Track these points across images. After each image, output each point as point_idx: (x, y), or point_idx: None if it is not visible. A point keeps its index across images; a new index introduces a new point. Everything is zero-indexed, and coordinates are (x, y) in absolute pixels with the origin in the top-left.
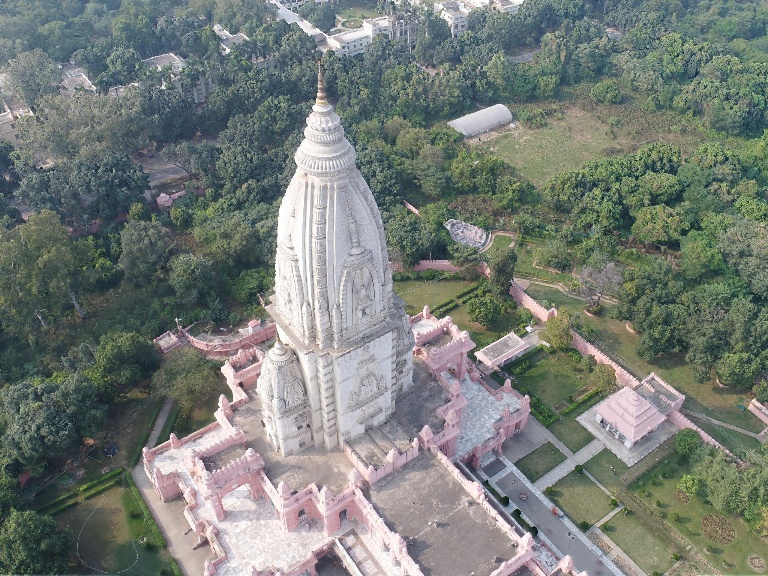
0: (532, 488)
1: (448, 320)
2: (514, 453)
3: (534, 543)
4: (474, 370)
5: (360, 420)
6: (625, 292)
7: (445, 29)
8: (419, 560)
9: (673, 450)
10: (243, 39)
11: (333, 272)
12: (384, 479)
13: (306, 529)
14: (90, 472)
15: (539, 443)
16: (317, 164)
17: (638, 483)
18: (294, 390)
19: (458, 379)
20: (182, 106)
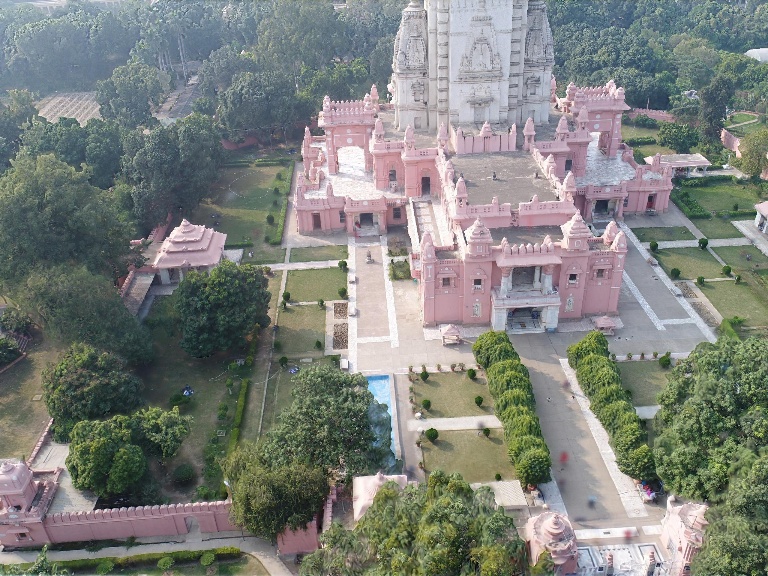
0: (637, 244)
1: (610, 84)
2: (637, 223)
3: None
4: None
5: (469, 99)
6: None
7: None
8: None
9: None
10: None
11: None
12: (471, 154)
13: (392, 191)
14: (270, 156)
15: (671, 224)
16: None
17: None
18: (416, 47)
19: (608, 157)
20: None
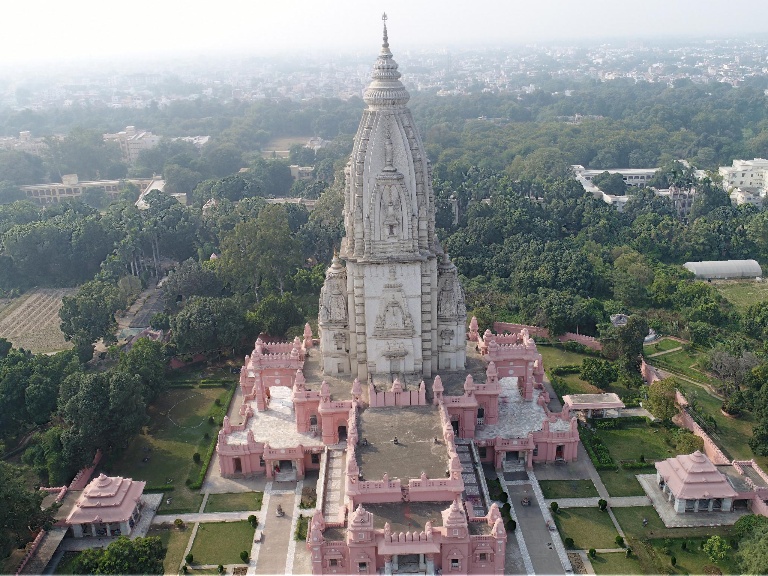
0: (541, 501)
1: (524, 331)
2: (545, 474)
3: (461, 470)
4: (547, 400)
5: (384, 353)
6: (748, 373)
7: (723, 198)
8: (361, 455)
9: (734, 533)
10: (521, 179)
11: (368, 183)
12: (383, 408)
13: (312, 435)
14: (215, 376)
15: (578, 477)
16: (371, 93)
17: (664, 540)
18: (337, 303)
19: (525, 399)
20: (442, 208)
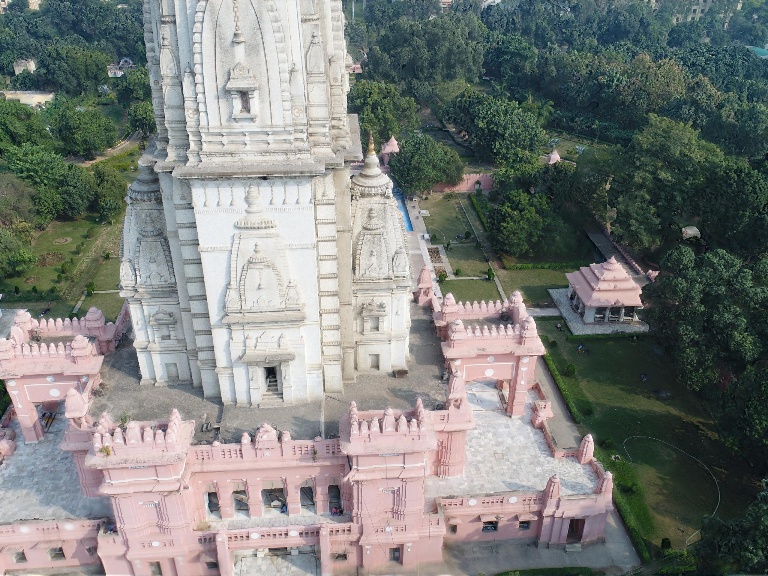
0: None
1: None
2: None
3: None
4: None
5: None
6: None
7: None
8: None
9: None
10: None
11: None
12: None
13: None
14: None
15: None
16: None
17: (46, 296)
18: None
19: None
20: None
